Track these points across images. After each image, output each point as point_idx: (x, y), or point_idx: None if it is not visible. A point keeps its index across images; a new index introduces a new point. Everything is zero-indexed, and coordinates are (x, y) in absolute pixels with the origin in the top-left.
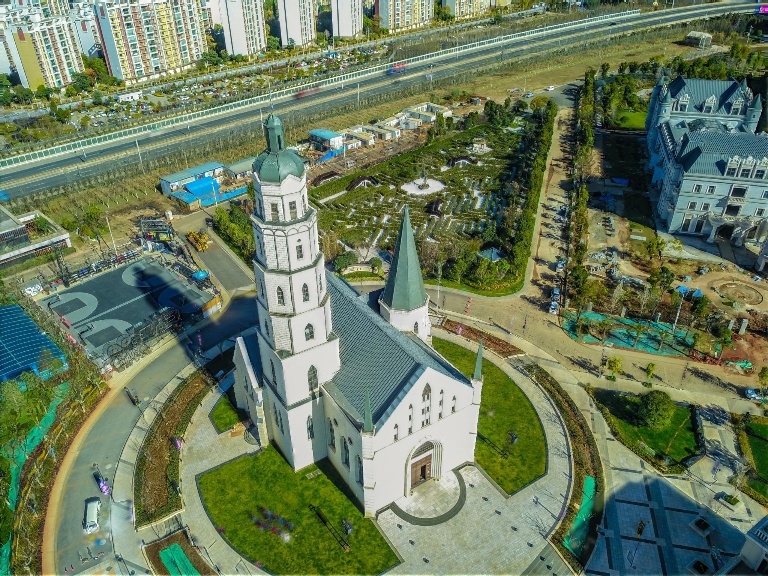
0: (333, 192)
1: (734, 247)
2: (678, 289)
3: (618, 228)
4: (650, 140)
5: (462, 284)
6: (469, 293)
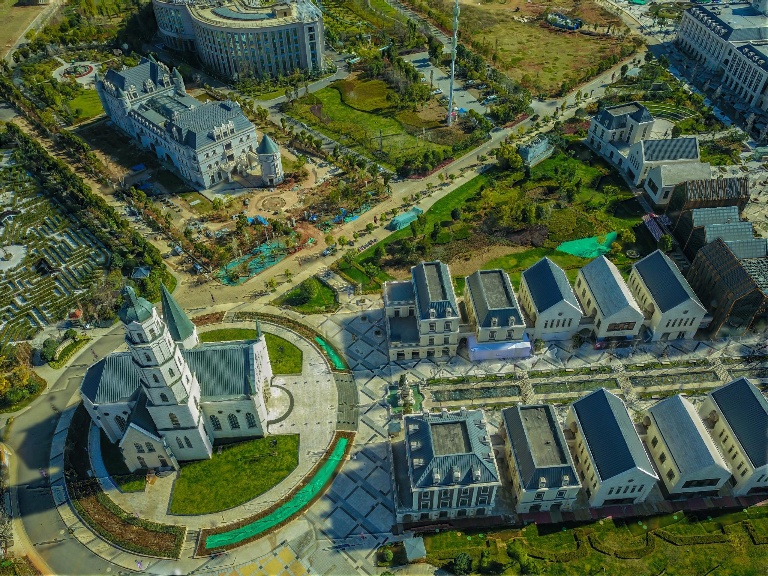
0: None
1: (245, 177)
2: (248, 221)
3: (177, 203)
4: (127, 126)
5: None
6: None
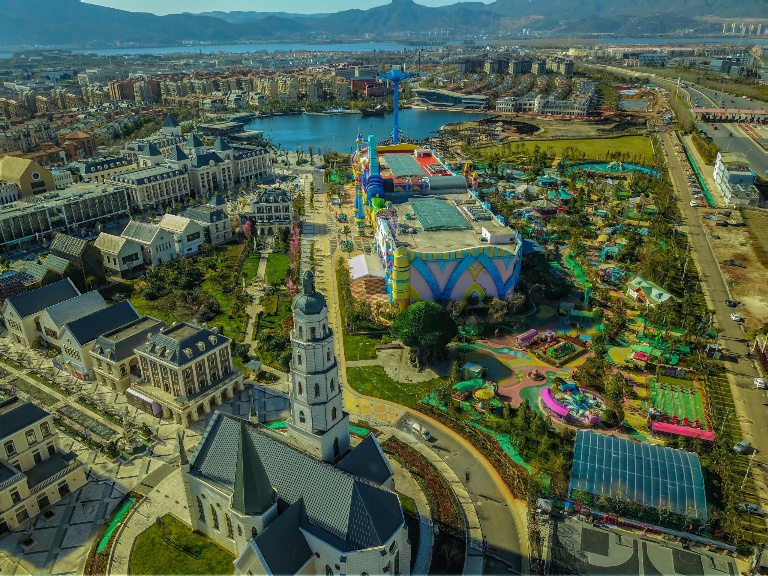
0: None
1: None
2: None
3: None
4: None
5: None
6: None
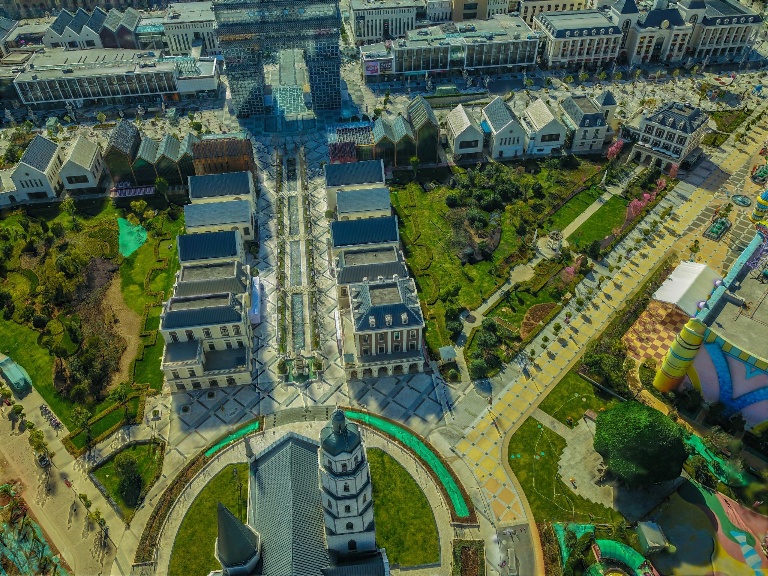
0: None
1: None
2: None
3: None
4: None
5: None
6: None
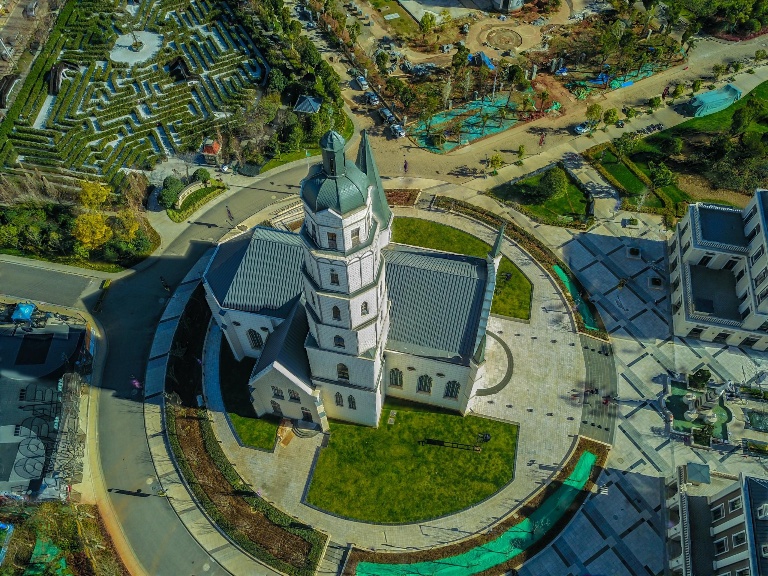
0: (38, 106)
1: None
2: None
3: (367, 13)
4: None
5: (302, 150)
6: (317, 157)
